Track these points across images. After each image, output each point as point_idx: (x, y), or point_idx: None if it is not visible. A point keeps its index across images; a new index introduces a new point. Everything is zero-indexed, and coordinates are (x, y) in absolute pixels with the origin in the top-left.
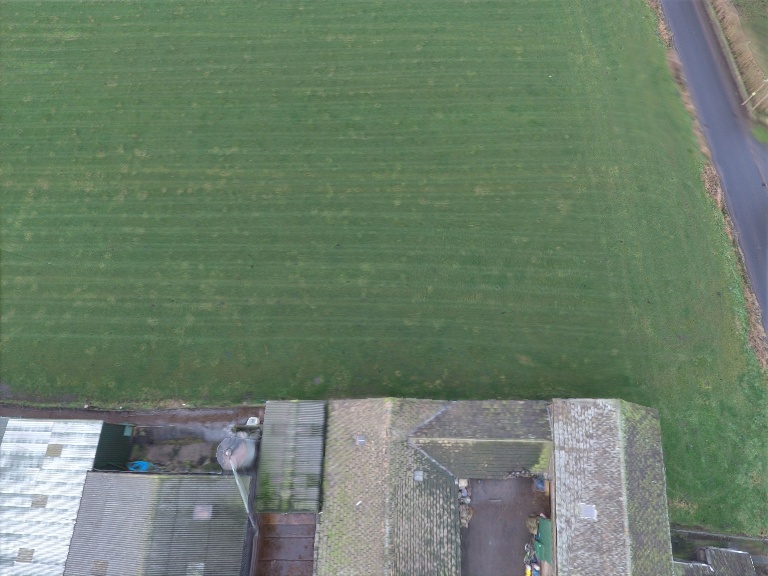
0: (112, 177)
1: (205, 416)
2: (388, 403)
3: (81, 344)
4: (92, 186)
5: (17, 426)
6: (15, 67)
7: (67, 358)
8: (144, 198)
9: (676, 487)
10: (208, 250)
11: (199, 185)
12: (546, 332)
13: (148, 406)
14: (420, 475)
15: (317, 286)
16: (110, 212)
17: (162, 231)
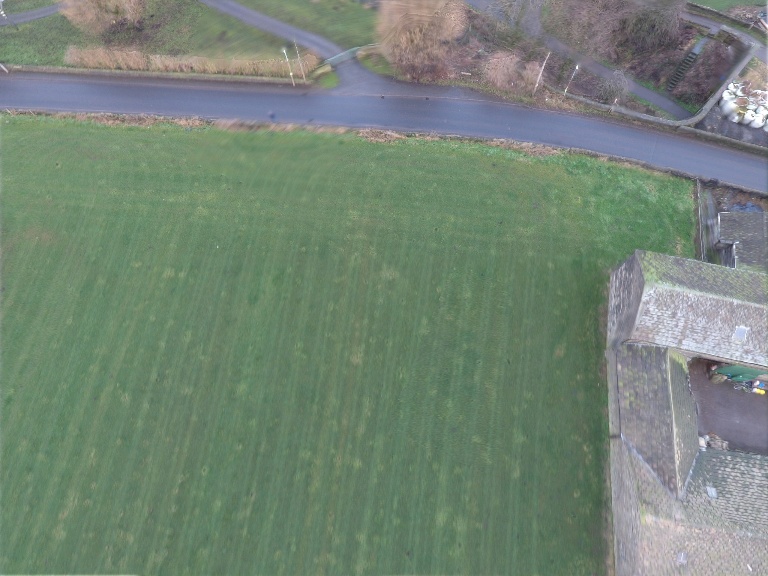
0: None
1: None
2: (647, 519)
3: None
4: None
5: None
6: None
7: None
8: None
9: (665, 248)
10: None
11: None
12: (531, 323)
13: None
14: (711, 490)
15: None
16: None
17: None
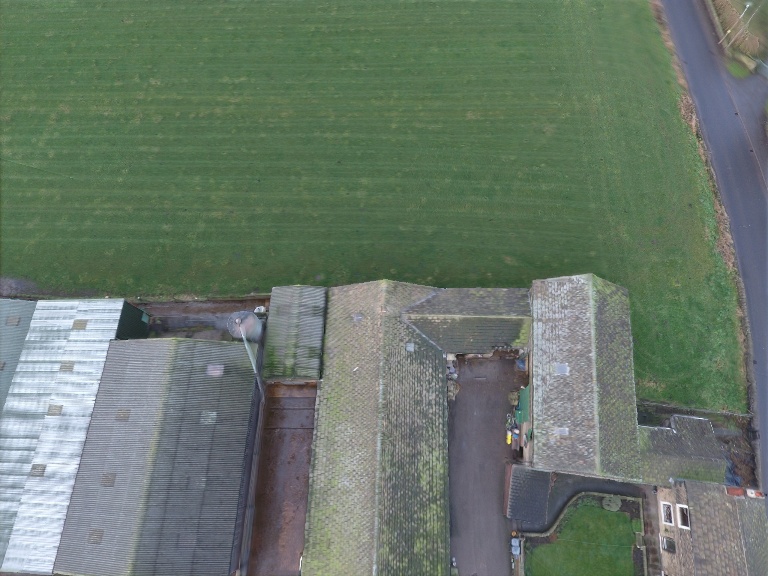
0: (129, 103)
1: (215, 308)
2: (383, 284)
3: (101, 247)
4: (110, 111)
5: (45, 306)
6: (37, 6)
7: (88, 259)
8: (159, 121)
9: (646, 369)
10: (218, 166)
11: (210, 110)
12: (530, 236)
13: (163, 299)
14: (411, 347)
15: (319, 197)
16: (127, 133)
17: (176, 150)
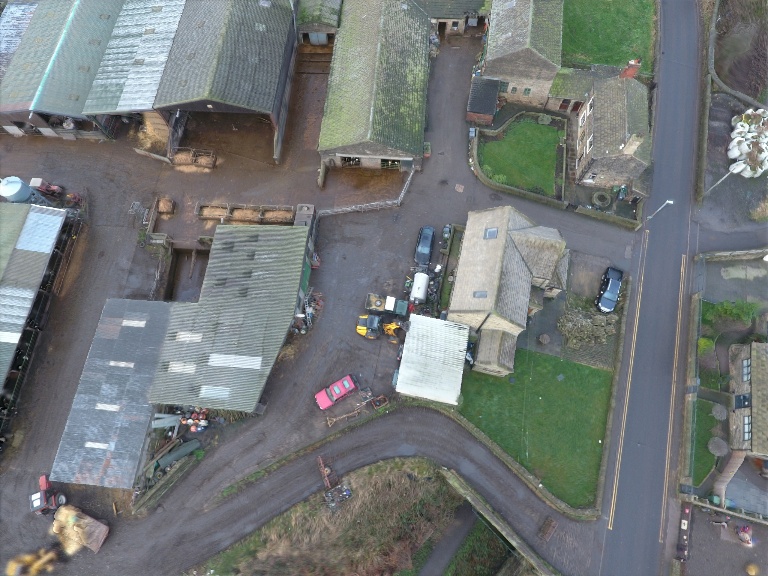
0: None
1: None
2: None
3: None
4: None
5: None
6: None
7: None
8: None
9: (579, 49)
10: None
11: None
12: None
13: None
14: (405, 6)
15: None
16: None
17: None
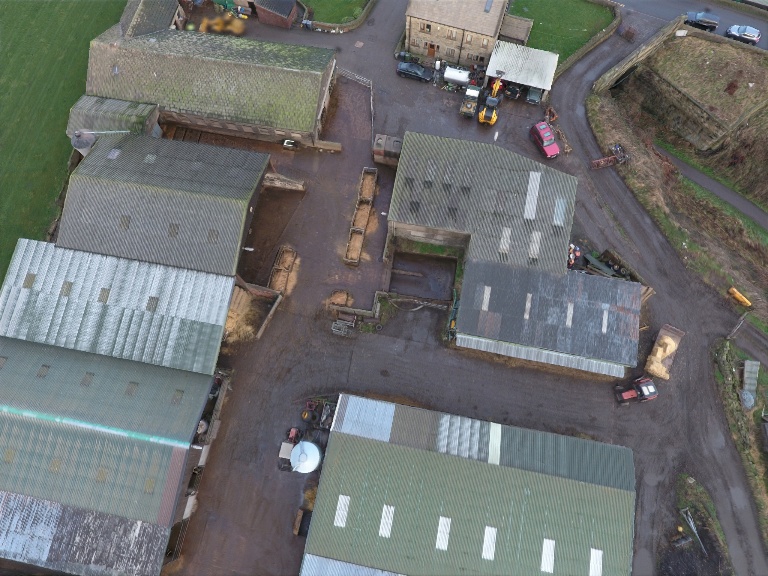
0: None
1: None
2: (93, 43)
3: None
4: None
5: None
6: None
7: None
8: None
9: None
10: None
11: None
12: None
13: None
14: (152, 40)
15: (2, 116)
16: None
17: None
